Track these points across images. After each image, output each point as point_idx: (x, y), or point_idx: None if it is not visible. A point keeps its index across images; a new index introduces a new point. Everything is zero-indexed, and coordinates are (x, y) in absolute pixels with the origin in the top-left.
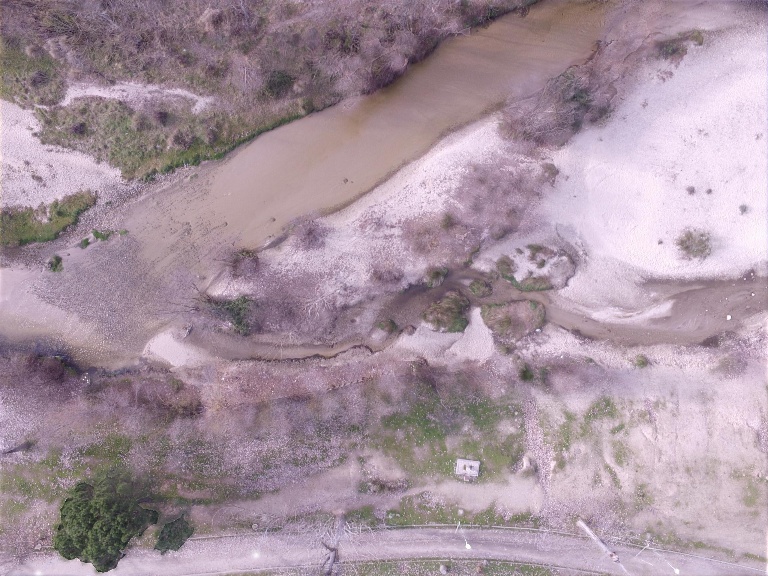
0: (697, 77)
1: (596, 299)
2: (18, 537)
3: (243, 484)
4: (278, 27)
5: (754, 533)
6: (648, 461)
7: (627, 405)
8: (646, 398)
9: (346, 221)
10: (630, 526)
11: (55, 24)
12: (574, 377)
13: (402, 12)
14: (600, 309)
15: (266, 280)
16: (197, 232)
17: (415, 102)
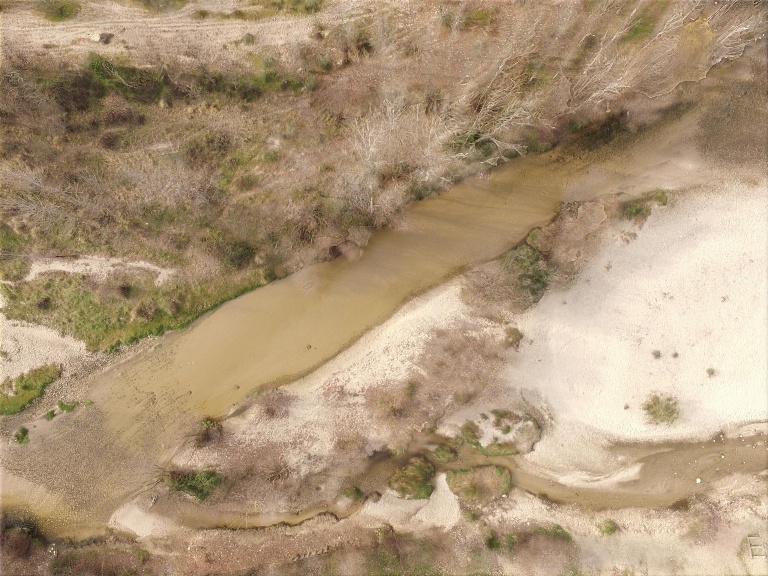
0: (661, 238)
1: (563, 463)
2: None
3: None
4: (239, 199)
5: None
6: None
7: (595, 574)
8: (614, 566)
9: (310, 389)
10: None
11: (19, 202)
12: (541, 545)
13: (362, 181)
14: (567, 473)
15: (230, 450)
16: (162, 401)
17: (377, 267)
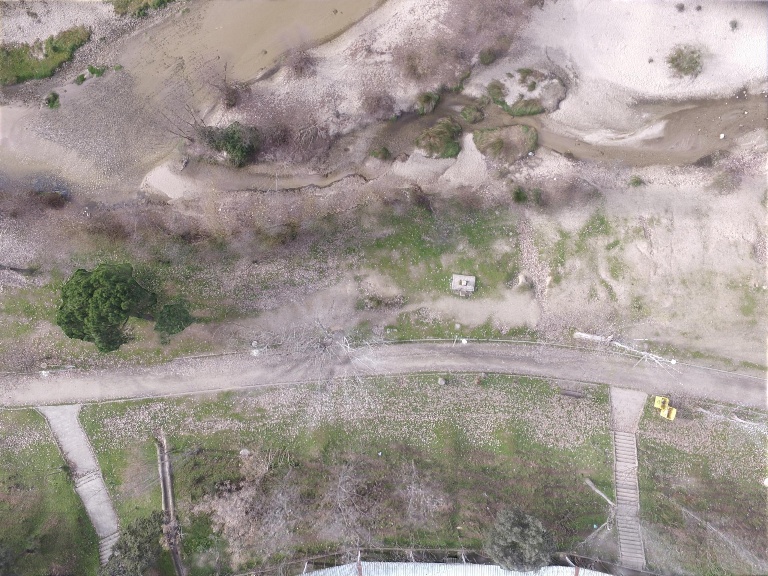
0: None
1: (588, 121)
2: (24, 357)
3: (242, 304)
4: None
5: (752, 342)
6: (644, 274)
7: (621, 223)
8: (640, 216)
9: (337, 50)
10: (627, 337)
11: None
12: (568, 197)
13: None
14: (592, 131)
15: (259, 110)
16: (190, 66)
17: None
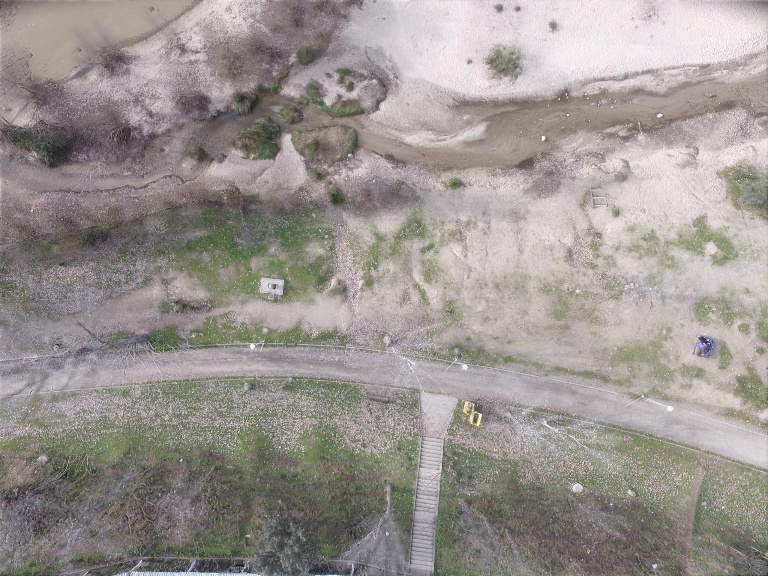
0: None
1: (408, 123)
2: None
3: (45, 307)
4: None
5: (564, 346)
6: (457, 278)
7: (438, 225)
8: (458, 218)
9: (152, 49)
10: (438, 342)
11: None
12: (385, 199)
13: None
14: (413, 133)
15: (71, 109)
16: (2, 64)
17: None
